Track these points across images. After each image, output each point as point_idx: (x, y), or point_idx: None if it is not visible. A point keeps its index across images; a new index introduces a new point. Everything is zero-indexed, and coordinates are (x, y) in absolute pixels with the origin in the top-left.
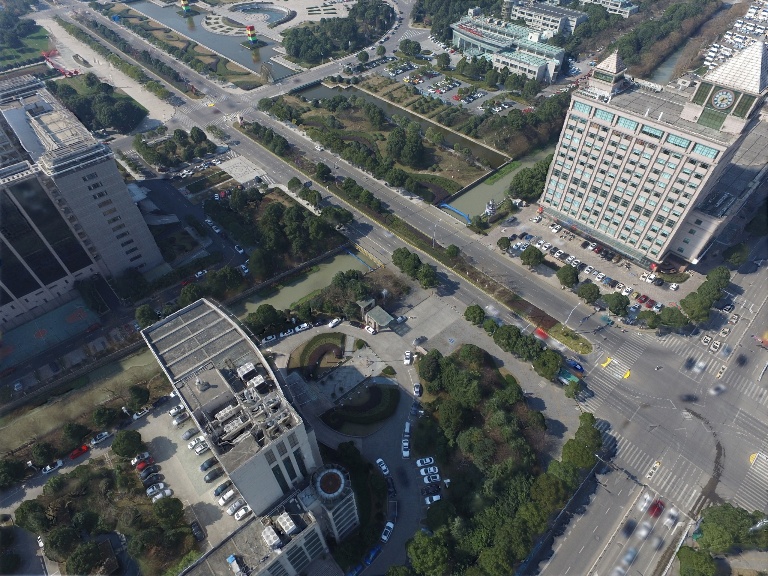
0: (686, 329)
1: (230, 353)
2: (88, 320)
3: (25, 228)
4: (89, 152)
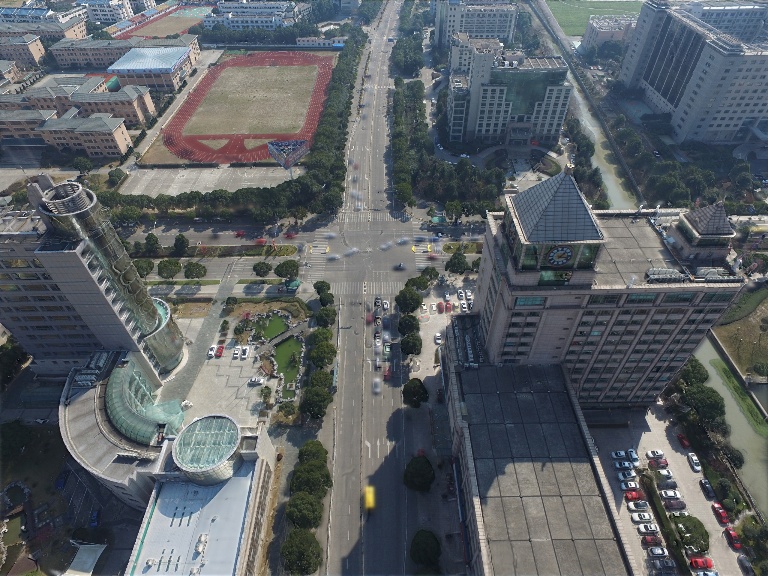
0: None
1: None
2: (638, 120)
3: (690, 64)
4: (725, 44)
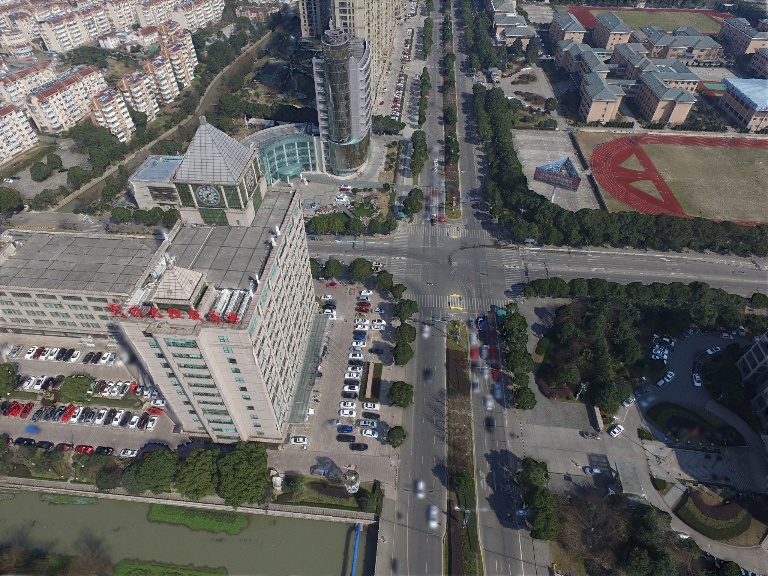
0: (373, 281)
1: None
2: None
3: None
4: None
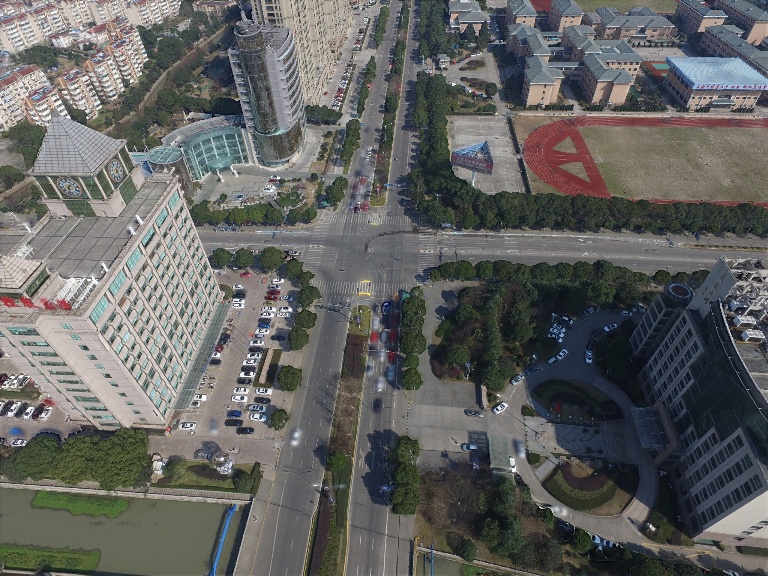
0: None
1: (767, 369)
2: None
3: None
4: None
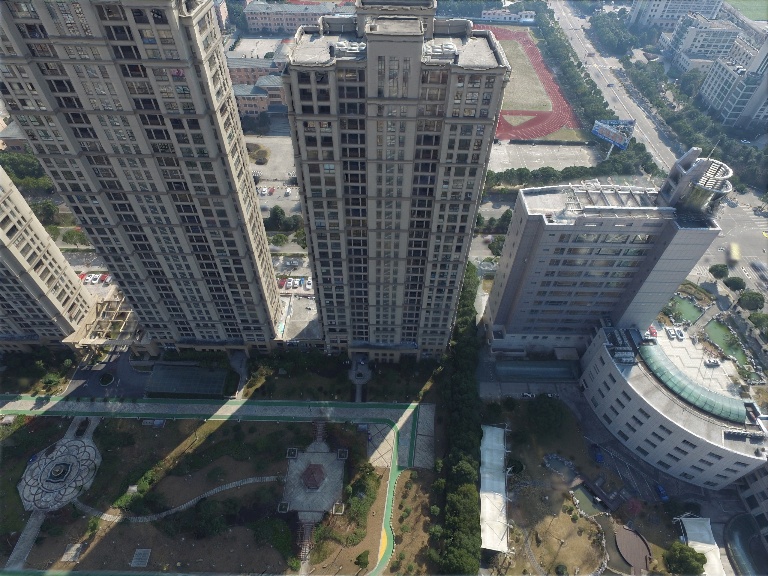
0: None
1: None
2: None
3: None
4: None
